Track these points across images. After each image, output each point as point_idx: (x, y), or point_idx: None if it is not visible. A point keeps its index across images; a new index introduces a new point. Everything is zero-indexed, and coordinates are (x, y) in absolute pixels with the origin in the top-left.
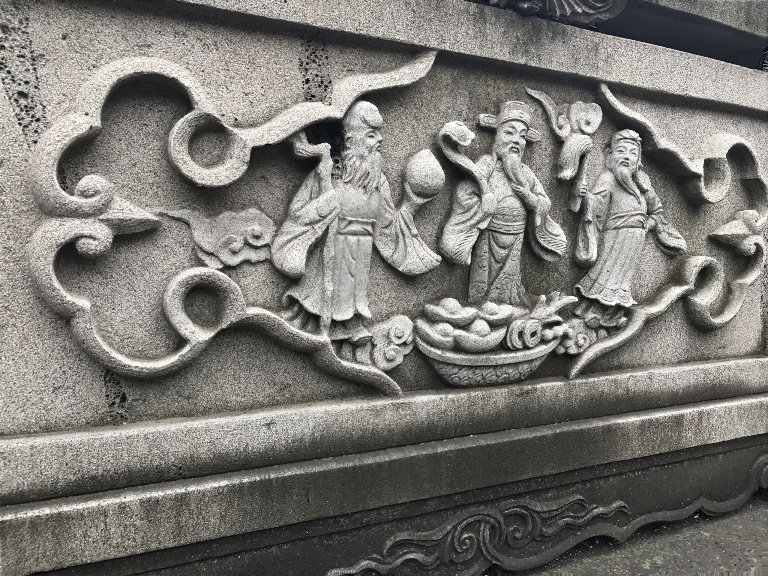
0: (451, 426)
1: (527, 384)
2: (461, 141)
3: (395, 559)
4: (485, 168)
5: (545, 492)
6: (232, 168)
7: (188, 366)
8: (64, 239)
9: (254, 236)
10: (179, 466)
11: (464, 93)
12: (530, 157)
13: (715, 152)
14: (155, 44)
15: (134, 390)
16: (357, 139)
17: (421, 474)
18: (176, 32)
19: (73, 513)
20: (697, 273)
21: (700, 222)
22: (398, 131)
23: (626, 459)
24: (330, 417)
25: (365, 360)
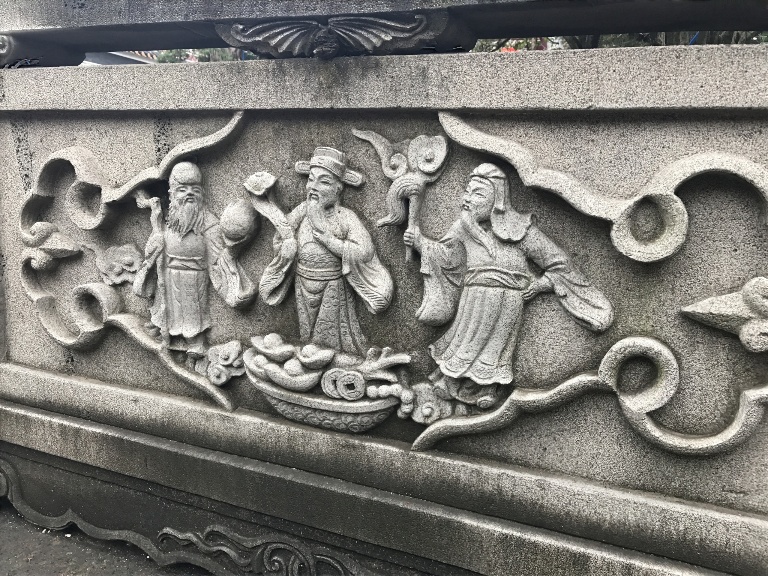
0: (272, 452)
1: (358, 438)
2: (257, 191)
3: (214, 545)
4: (295, 214)
5: (370, 559)
6: (96, 217)
7: (100, 347)
8: (24, 259)
9: (126, 264)
10: (88, 411)
11: (286, 143)
12: (362, 201)
13: (658, 185)
14: (78, 137)
15: (76, 356)
16: (172, 193)
17: (229, 482)
18: (87, 128)
19: (31, 418)
20: (613, 361)
21: (664, 288)
22: (229, 182)
23: (479, 572)
24: (174, 409)
25: (201, 372)
